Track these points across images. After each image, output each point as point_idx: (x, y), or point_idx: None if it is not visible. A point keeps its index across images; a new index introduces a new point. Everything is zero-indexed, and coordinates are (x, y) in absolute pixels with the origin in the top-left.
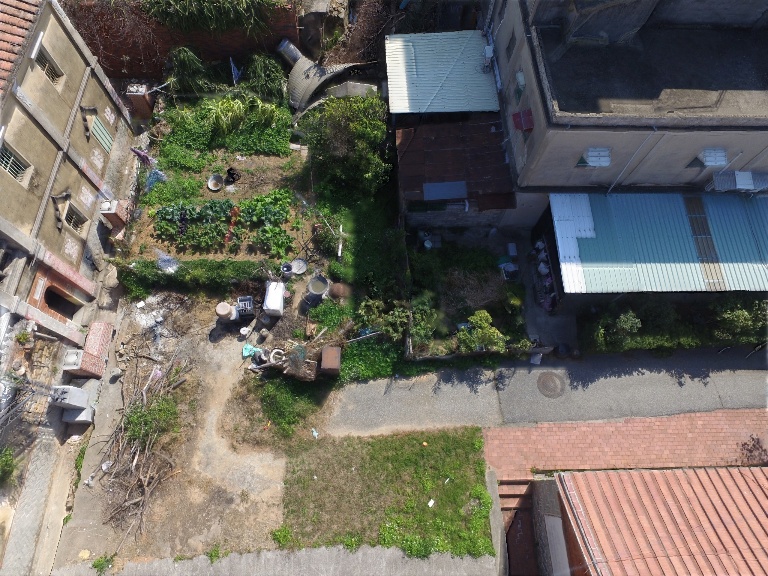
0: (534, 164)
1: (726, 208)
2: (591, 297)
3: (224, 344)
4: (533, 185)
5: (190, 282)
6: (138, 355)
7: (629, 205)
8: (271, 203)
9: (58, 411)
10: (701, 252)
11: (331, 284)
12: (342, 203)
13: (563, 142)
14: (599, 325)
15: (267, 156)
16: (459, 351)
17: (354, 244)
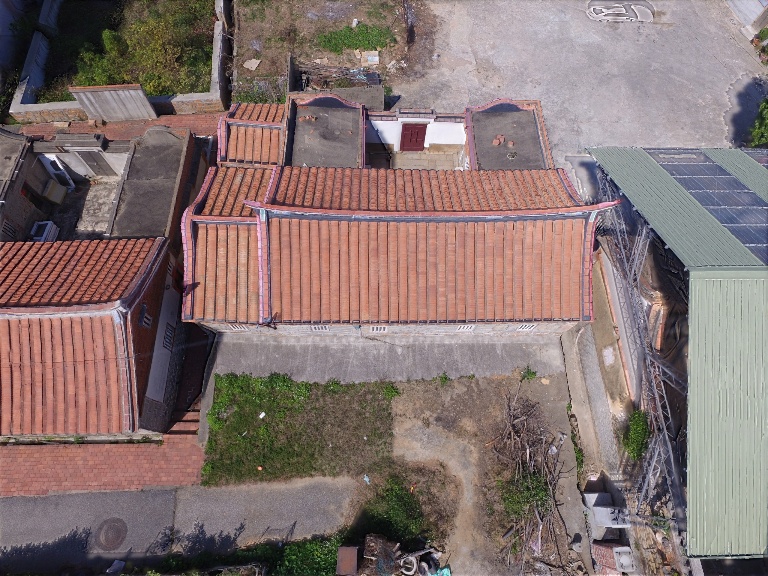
0: None
1: None
2: None
3: None
4: None
5: None
6: (562, 569)
7: None
8: None
9: (618, 503)
10: None
11: None
12: None
13: None
14: None
15: None
16: (204, 575)
17: None
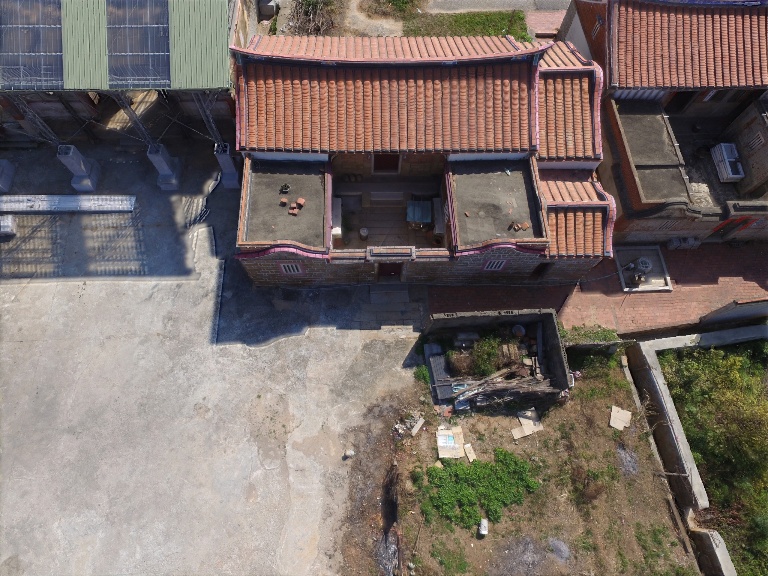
0: None
1: None
2: None
3: None
4: None
5: None
6: None
7: None
8: None
9: None
10: None
11: None
12: None
13: None
14: None
15: None
16: None
17: None
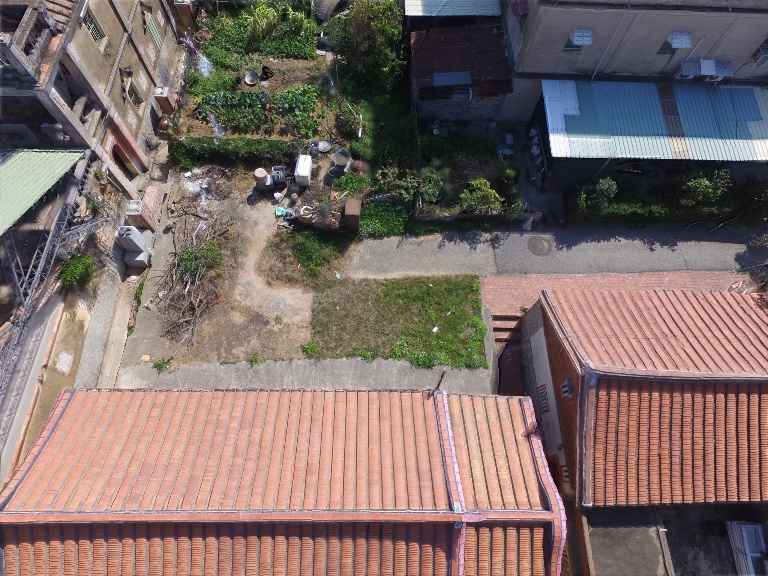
0: (528, 46)
1: (693, 94)
2: (577, 179)
3: (260, 206)
4: (528, 71)
5: (230, 157)
6: (187, 213)
7: (610, 90)
8: (300, 94)
9: (120, 252)
10: (670, 128)
11: (352, 161)
12: (362, 97)
13: (553, 21)
14: (581, 191)
15: (296, 59)
16: None
17: (372, 129)
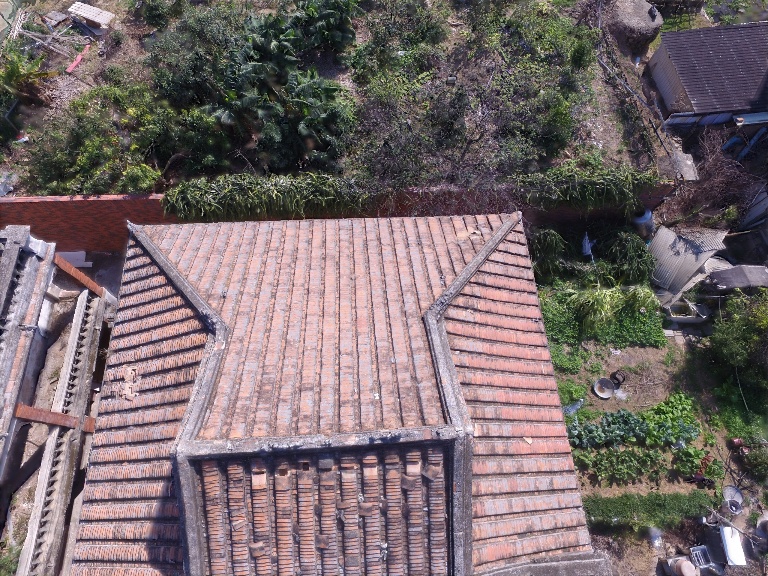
0: None
1: None
2: None
3: None
4: None
5: None
6: None
7: None
8: None
9: None
10: None
11: None
12: (749, 408)
13: None
14: None
15: (642, 347)
16: None
17: None
